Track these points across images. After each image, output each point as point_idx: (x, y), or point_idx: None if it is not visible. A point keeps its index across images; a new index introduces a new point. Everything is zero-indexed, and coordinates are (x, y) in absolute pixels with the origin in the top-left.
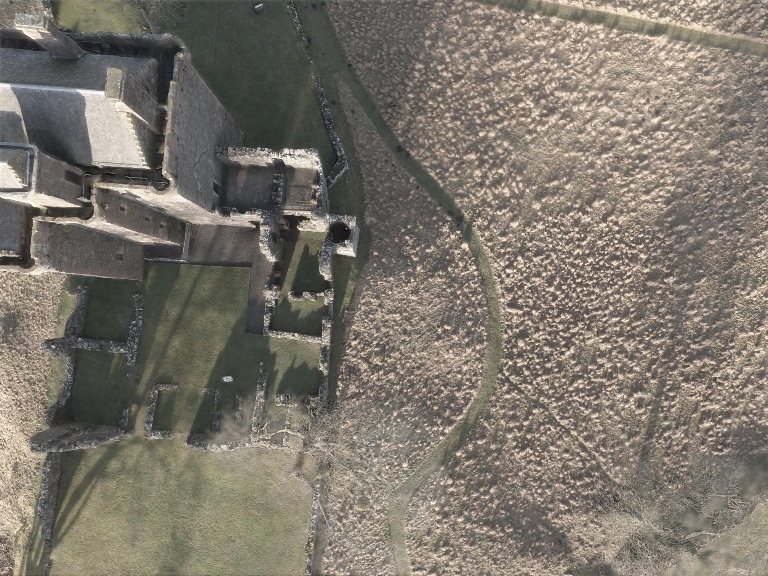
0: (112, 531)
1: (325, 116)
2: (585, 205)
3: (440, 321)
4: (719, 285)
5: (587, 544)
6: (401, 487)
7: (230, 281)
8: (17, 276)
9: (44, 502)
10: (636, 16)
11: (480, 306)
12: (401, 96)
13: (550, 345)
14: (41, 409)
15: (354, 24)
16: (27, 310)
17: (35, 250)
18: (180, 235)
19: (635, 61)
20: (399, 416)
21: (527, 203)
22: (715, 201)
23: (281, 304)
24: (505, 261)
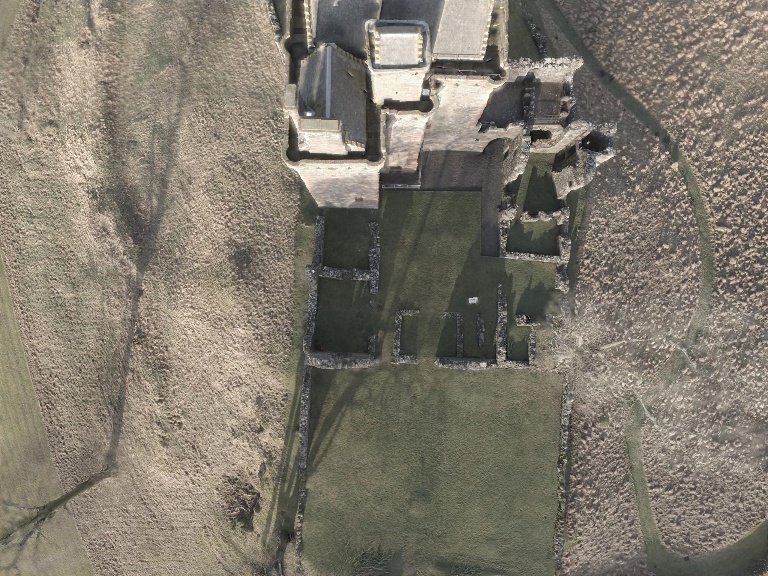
0: (363, 458)
1: (541, 39)
2: None
3: (658, 240)
4: None
5: None
6: (636, 405)
7: (462, 206)
8: (244, 214)
9: (305, 429)
10: None
11: (691, 226)
12: (601, 21)
13: (760, 262)
14: (287, 340)
15: None
16: (259, 246)
17: None
18: None
19: None
20: (629, 335)
21: (728, 122)
22: None
23: (514, 226)
24: (712, 180)
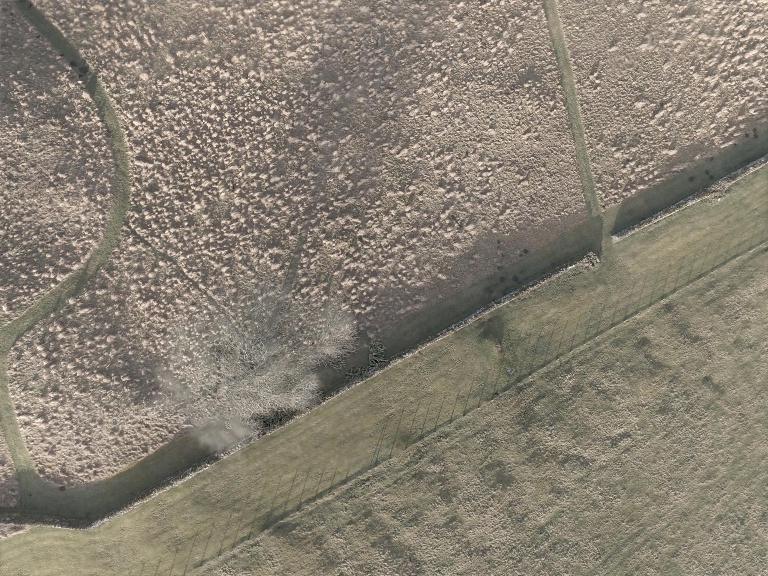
0: None
1: None
2: (224, 60)
3: (54, 169)
4: (367, 143)
5: (209, 395)
6: (2, 331)
7: None
8: None
9: None
10: None
11: (105, 158)
12: None
13: (181, 199)
14: None
15: None
16: None
17: None
18: None
19: None
20: (2, 260)
21: (160, 56)
22: (366, 59)
23: None
24: (133, 113)
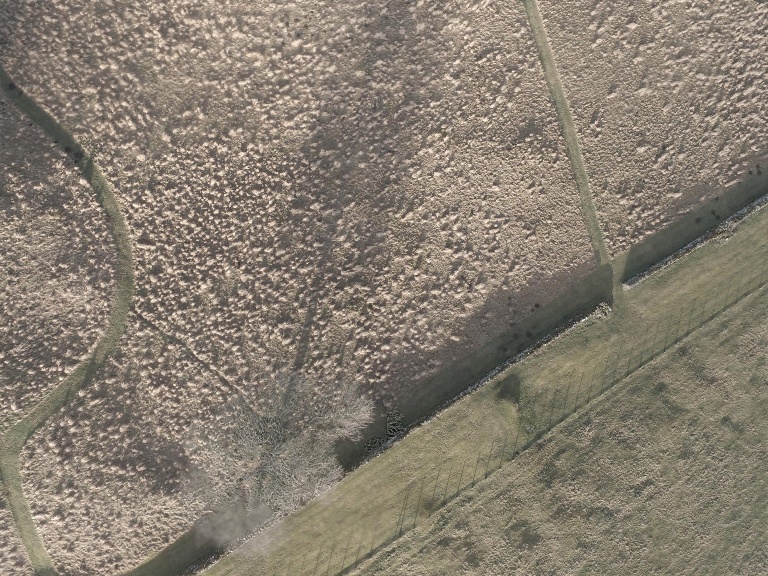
0: None
1: None
2: (221, 135)
3: (55, 260)
4: (371, 209)
5: (228, 479)
6: (12, 430)
7: None
8: None
9: None
10: None
11: (106, 243)
12: (12, 32)
13: (187, 279)
14: None
15: None
16: None
17: None
18: None
19: None
20: (7, 358)
21: (157, 136)
22: (364, 124)
23: None
24: (132, 196)
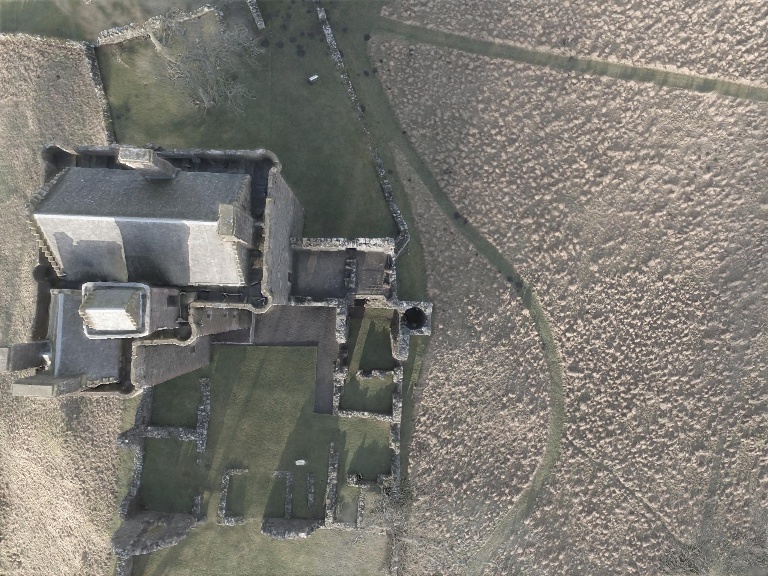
0: None
1: (386, 189)
2: (641, 264)
3: (504, 389)
4: None
5: None
6: None
7: (297, 361)
8: None
9: None
10: (685, 72)
11: (542, 371)
12: (457, 162)
13: (612, 407)
14: (111, 499)
15: (407, 90)
16: None
17: (135, 376)
18: (247, 318)
19: (685, 118)
20: (468, 488)
21: (584, 265)
22: (767, 255)
23: (349, 382)
24: (565, 325)
